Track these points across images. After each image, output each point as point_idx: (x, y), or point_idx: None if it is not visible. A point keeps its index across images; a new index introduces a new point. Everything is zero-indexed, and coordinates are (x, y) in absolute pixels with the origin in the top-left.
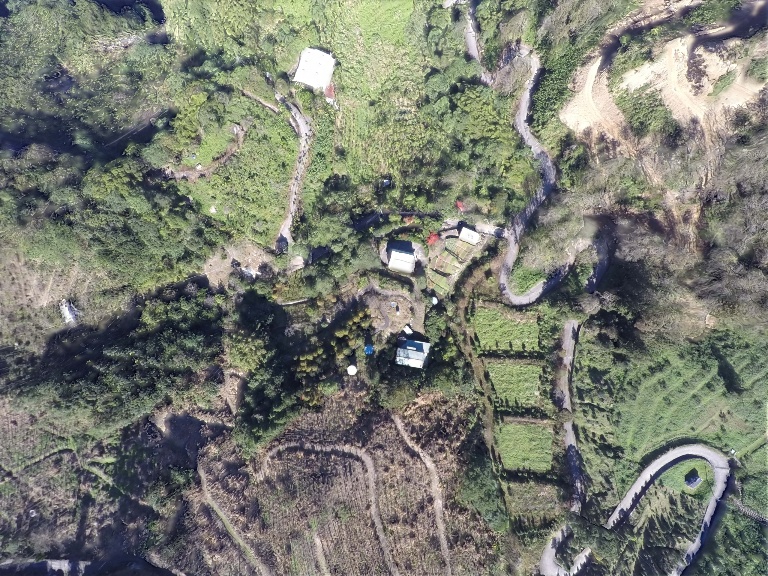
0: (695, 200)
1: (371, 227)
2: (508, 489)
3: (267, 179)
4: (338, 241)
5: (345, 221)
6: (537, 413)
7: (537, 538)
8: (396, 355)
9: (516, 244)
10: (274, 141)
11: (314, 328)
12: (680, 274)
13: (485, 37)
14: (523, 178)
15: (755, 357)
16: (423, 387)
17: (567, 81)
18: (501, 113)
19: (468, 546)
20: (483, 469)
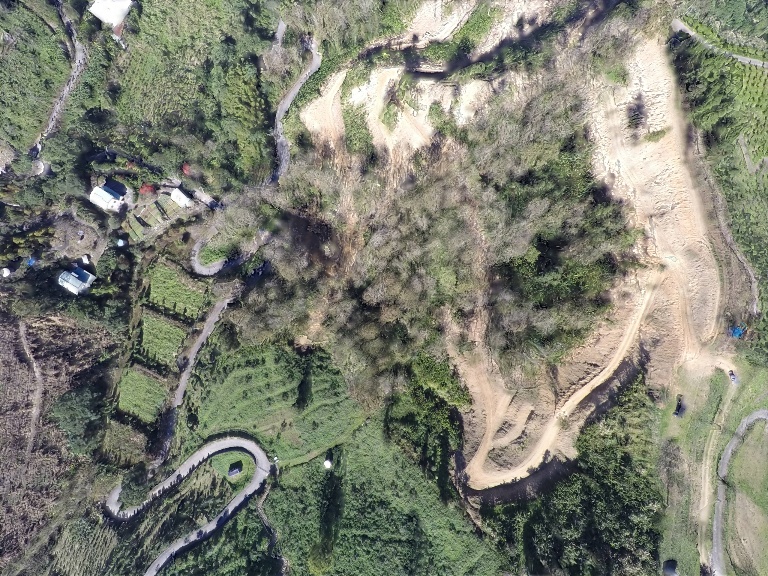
0: (366, 228)
1: (94, 160)
2: (108, 424)
3: (27, 90)
4: (56, 162)
5: (71, 147)
6: (164, 371)
7: (112, 473)
8: (59, 276)
9: None
10: (43, 58)
11: (10, 230)
12: (295, 285)
13: (285, 22)
14: (254, 162)
15: (337, 385)
16: (65, 310)
17: (320, 84)
18: (269, 98)
19: (52, 457)
20: (77, 395)
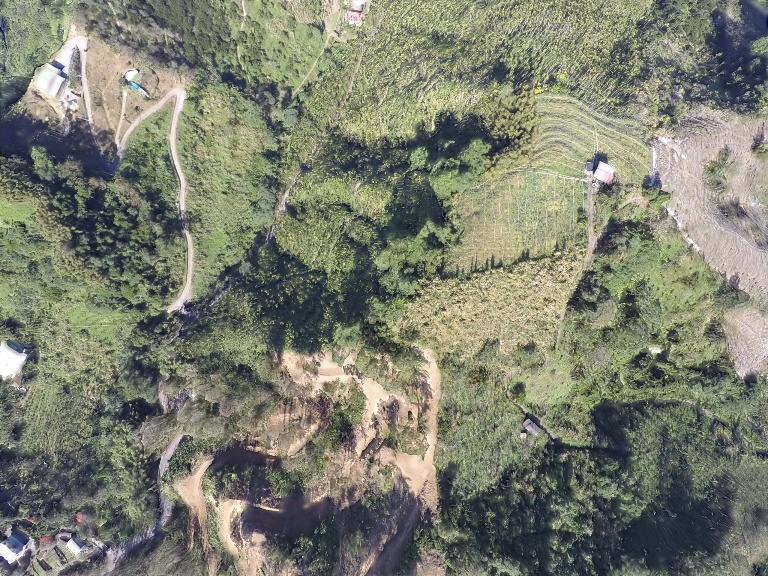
0: None
1: None
2: None
3: None
4: None
5: None
6: None
7: None
8: None
9: (114, 564)
10: None
11: None
12: None
13: None
14: (138, 515)
15: None
16: None
17: (190, 459)
18: None
19: None
20: None
